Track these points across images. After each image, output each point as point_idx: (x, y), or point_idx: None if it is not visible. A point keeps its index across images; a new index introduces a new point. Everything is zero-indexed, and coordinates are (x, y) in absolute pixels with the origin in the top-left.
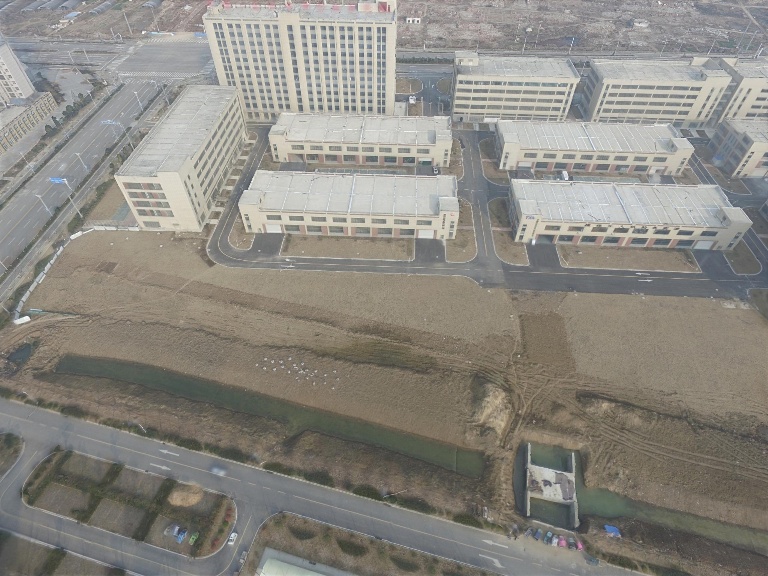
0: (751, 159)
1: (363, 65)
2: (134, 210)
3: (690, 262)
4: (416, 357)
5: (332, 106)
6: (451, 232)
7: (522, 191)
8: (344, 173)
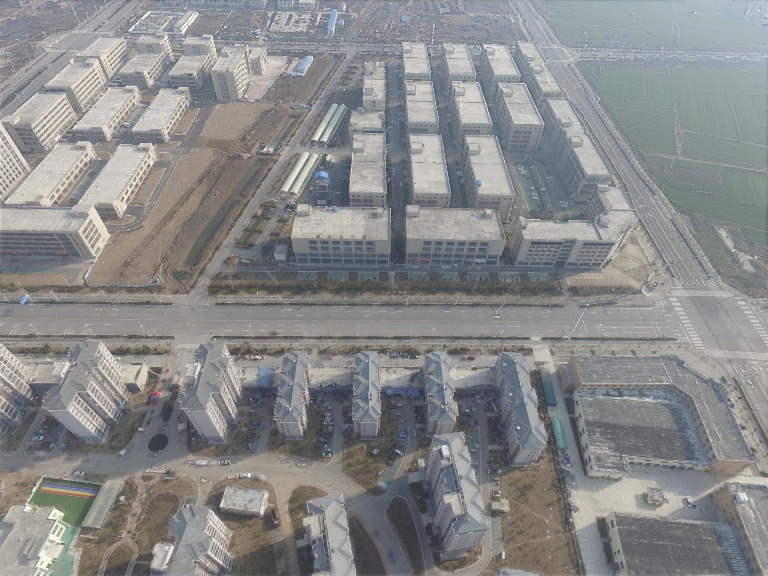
0: (147, 78)
1: (0, 150)
2: (90, 248)
3: (195, 109)
4: (217, 170)
5: (4, 187)
6: (155, 155)
7: (141, 130)
8: (98, 176)
